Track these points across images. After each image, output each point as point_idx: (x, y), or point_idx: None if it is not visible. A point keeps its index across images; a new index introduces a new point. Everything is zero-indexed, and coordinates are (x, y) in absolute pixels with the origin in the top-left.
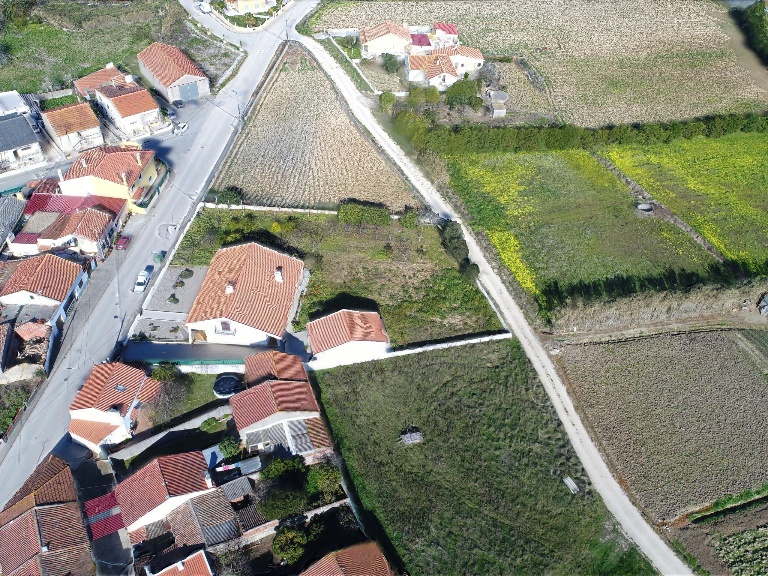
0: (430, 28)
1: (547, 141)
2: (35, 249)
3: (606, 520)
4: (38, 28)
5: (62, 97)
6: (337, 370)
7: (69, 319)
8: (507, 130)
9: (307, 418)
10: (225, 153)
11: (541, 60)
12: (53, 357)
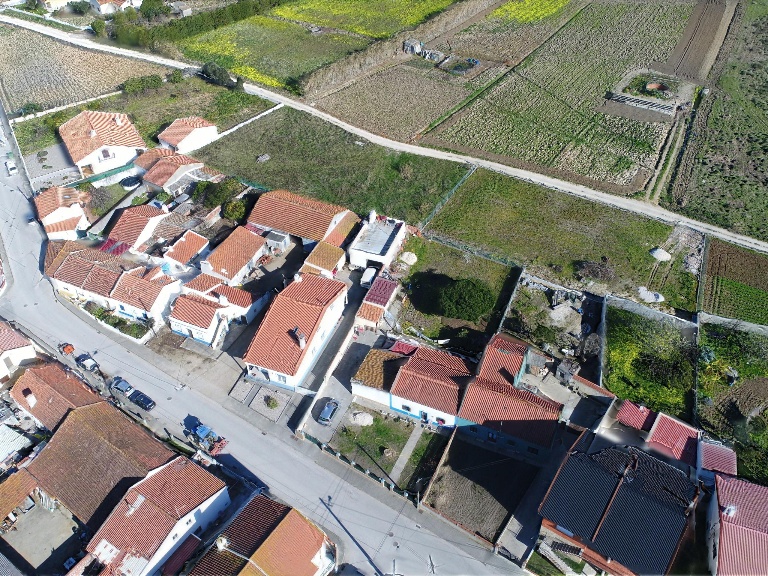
0: None
1: (233, 15)
2: None
3: (385, 149)
4: None
5: None
6: (194, 152)
7: None
8: (203, 14)
9: (198, 168)
10: None
11: None
12: None
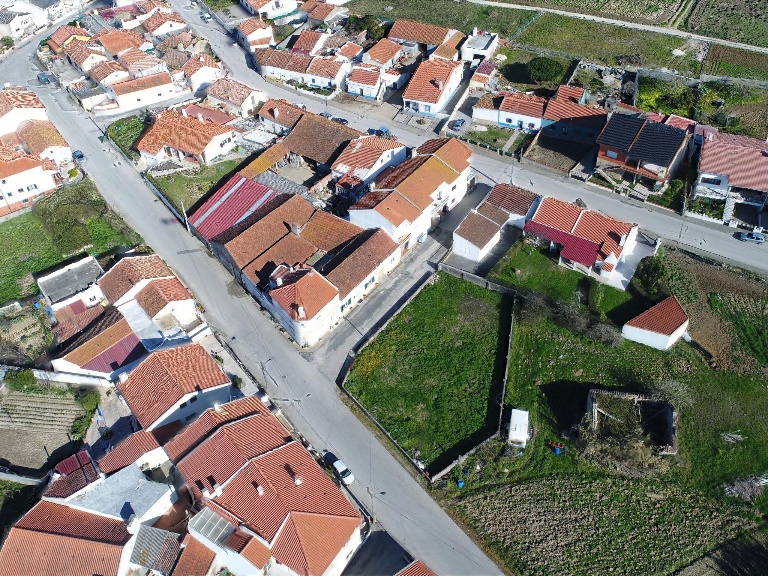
0: None
1: None
2: (138, 23)
3: (475, 4)
4: None
5: None
6: None
7: None
8: None
9: None
10: None
11: None
12: None
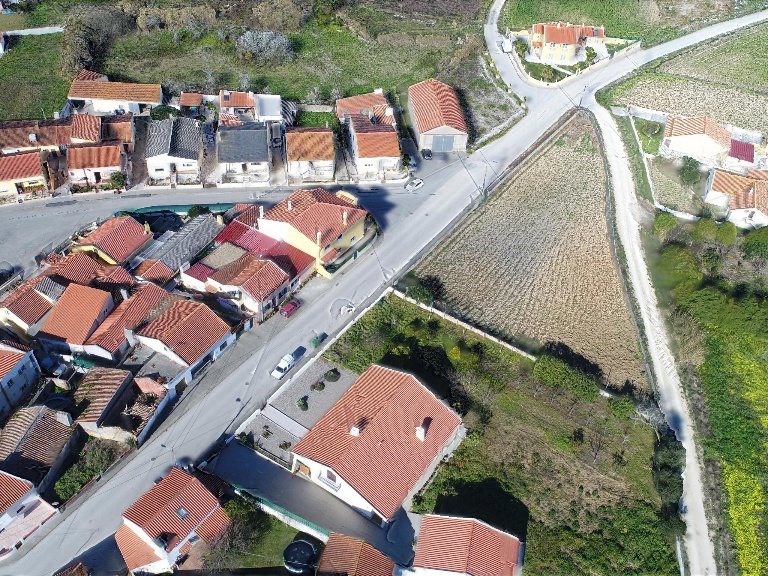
0: (762, 136)
1: None
2: (203, 287)
3: None
4: (337, 30)
5: (321, 112)
6: None
7: (194, 383)
8: None
9: None
10: (447, 230)
11: None
12: (156, 424)
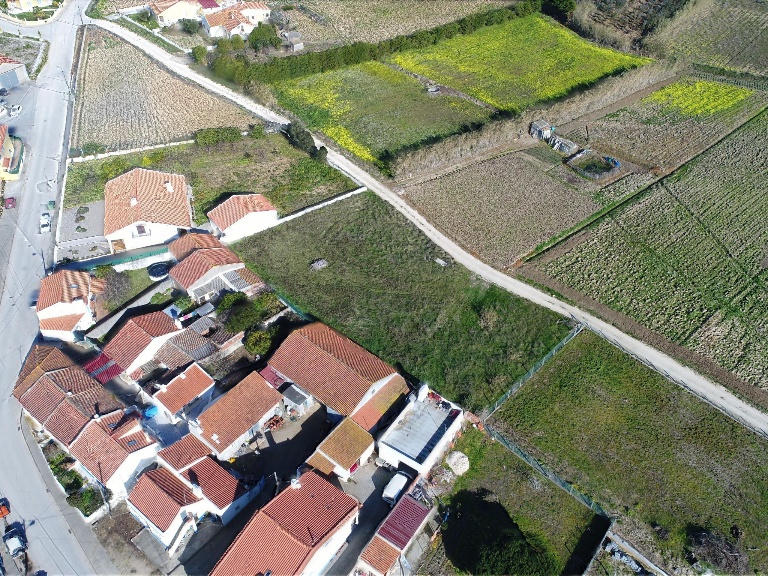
0: None
1: (345, 58)
2: None
3: (470, 275)
4: None
5: None
6: (244, 240)
7: None
8: (311, 54)
9: (236, 269)
10: (69, 121)
11: (317, 4)
12: None
